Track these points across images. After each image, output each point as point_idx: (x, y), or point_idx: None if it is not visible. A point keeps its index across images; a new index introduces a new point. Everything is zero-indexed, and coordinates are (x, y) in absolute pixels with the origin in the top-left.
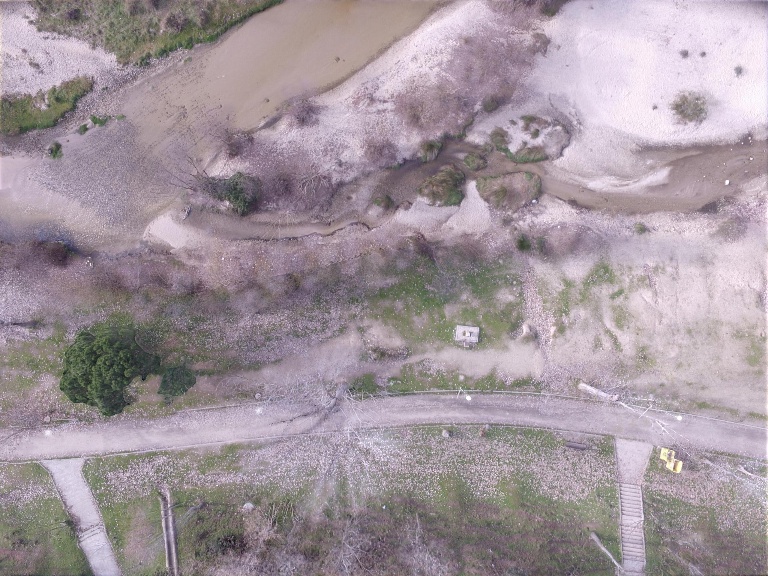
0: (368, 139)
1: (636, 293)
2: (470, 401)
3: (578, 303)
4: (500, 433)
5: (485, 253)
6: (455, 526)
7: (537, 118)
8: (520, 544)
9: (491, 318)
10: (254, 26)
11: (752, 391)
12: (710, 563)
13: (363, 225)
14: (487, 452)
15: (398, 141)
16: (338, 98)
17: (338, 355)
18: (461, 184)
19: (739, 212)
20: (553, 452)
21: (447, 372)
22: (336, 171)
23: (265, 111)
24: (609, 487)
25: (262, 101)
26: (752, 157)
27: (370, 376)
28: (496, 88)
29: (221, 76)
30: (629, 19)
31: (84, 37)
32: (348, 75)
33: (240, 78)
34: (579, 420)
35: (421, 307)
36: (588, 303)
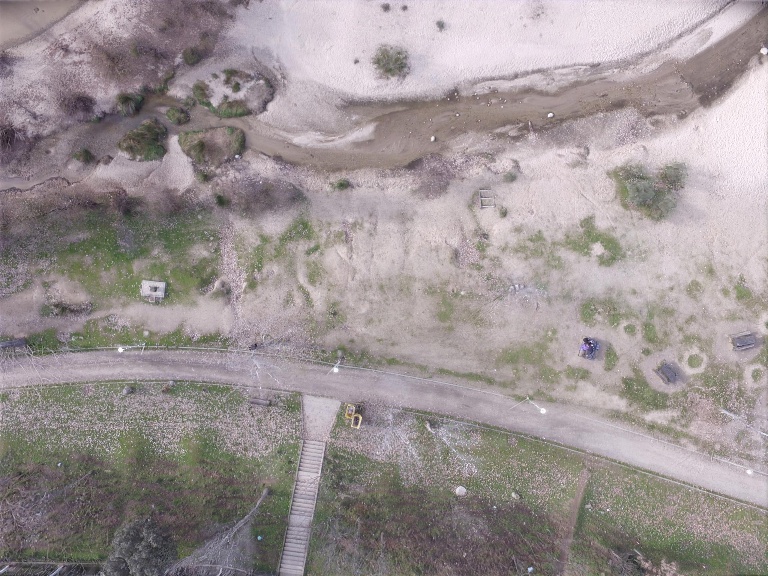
0: (65, 91)
1: (331, 249)
2: (155, 357)
3: (272, 259)
4: (184, 390)
5: (184, 209)
6: (126, 483)
7: (239, 72)
8: (186, 500)
9: (180, 273)
10: None
11: (442, 347)
12: (383, 518)
13: (63, 180)
14: (171, 409)
15: (96, 94)
16: (35, 49)
17: (19, 310)
18: (163, 138)
19: (444, 169)
20: (238, 409)
21: (132, 328)
22: (32, 124)
23: None
24: (292, 444)
25: None
26: (458, 113)
27: (51, 332)
28: (197, 40)
29: None
30: None
31: None
32: (48, 26)
33: None
34: (266, 376)
35: (110, 262)
36: (282, 259)
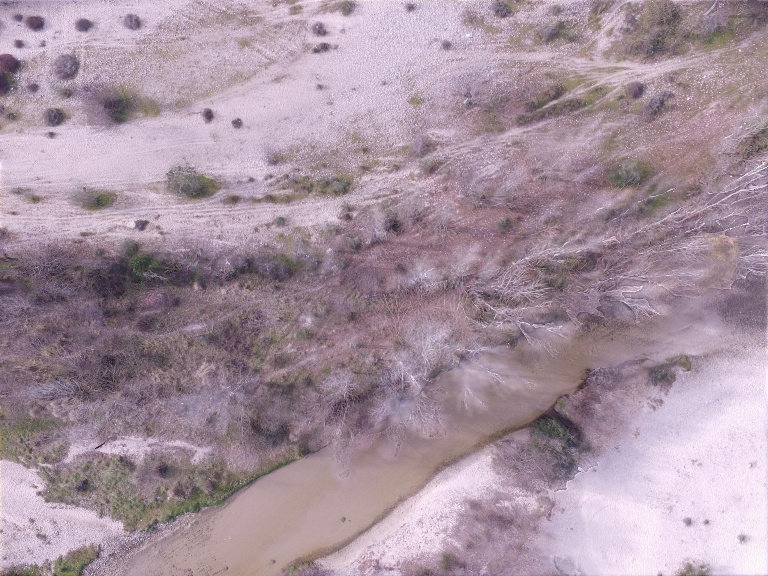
0: None
1: None
2: None
3: None
4: None
5: None
6: None
7: None
8: None
9: None
10: (261, 488)
11: None
12: None
13: None
14: None
15: None
16: (344, 561)
17: None
18: None
19: None
20: None
21: None
22: None
23: (271, 573)
24: None
25: (268, 563)
26: None
27: None
28: (501, 552)
29: (227, 538)
30: (632, 483)
31: (92, 507)
32: (354, 535)
33: (246, 539)
34: None
35: None
36: None
